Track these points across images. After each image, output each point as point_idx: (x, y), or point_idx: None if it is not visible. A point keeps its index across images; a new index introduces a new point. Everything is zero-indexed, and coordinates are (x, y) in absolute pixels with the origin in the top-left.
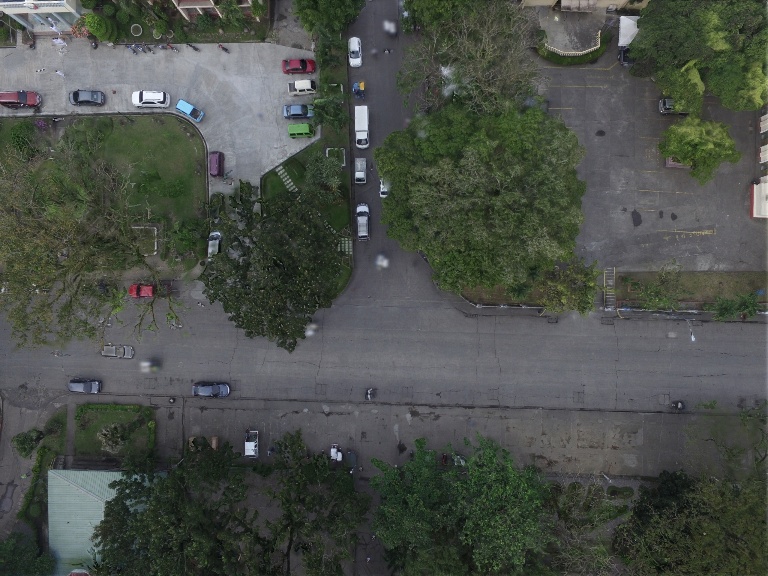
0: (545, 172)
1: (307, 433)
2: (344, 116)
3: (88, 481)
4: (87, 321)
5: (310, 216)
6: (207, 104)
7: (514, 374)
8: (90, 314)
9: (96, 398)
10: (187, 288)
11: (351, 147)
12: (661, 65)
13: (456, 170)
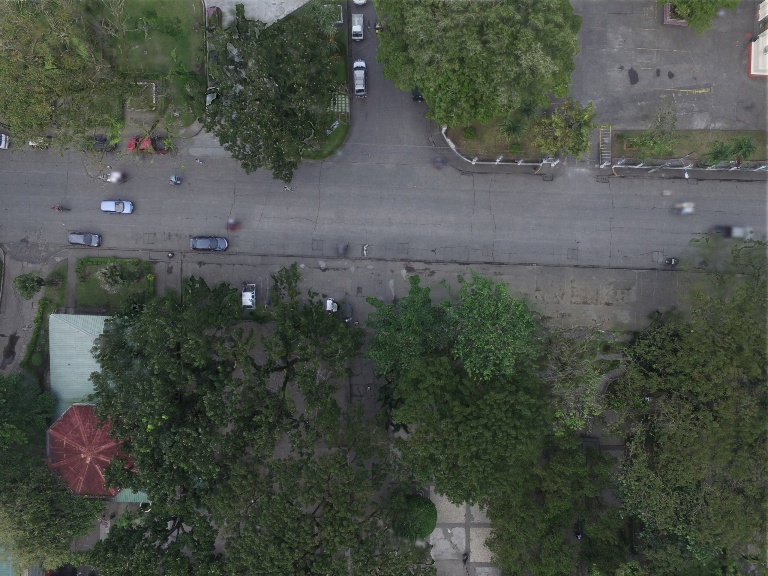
0: None
1: (304, 288)
2: None
3: (88, 324)
4: (85, 128)
5: (305, 36)
6: None
7: (509, 231)
8: (88, 122)
9: (96, 252)
10: (185, 145)
11: (348, 5)
12: None
13: None
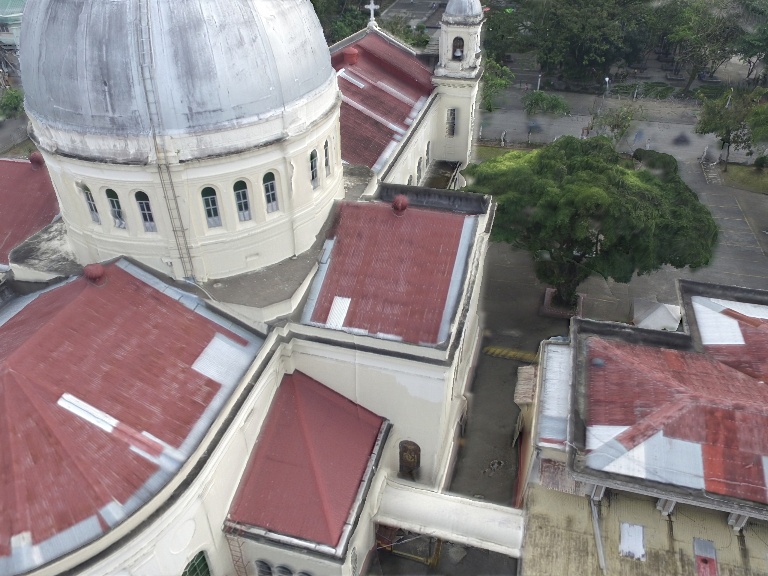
0: None
1: None
2: None
3: None
4: None
5: None
6: None
7: None
8: None
9: None
10: None
11: None
12: None
13: None
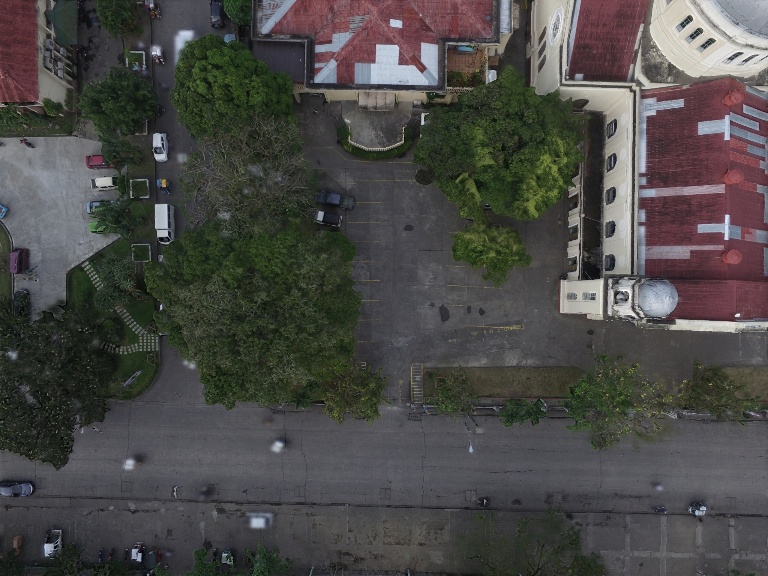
0: (293, 298)
1: (112, 531)
2: (127, 223)
3: None
4: None
5: (62, 340)
6: (12, 199)
7: (320, 471)
8: None
9: None
10: None
11: (158, 242)
12: (438, 175)
13: (203, 296)
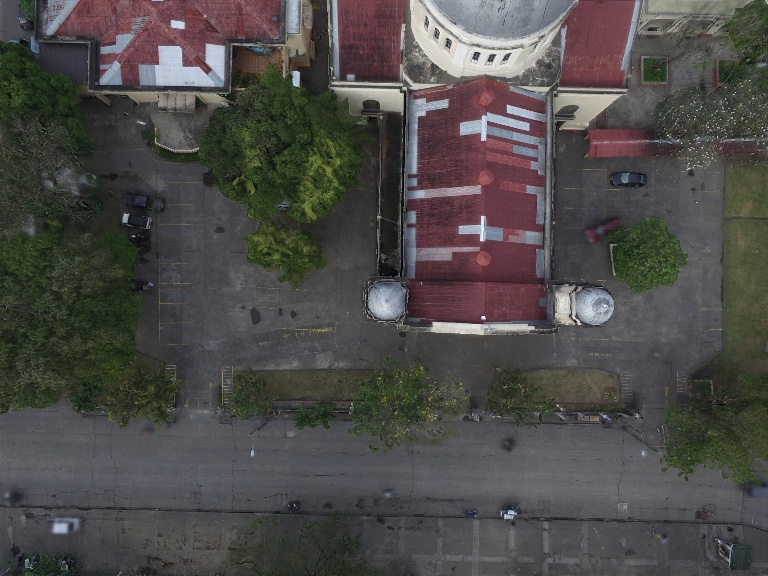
0: (44, 301)
1: None
2: None
3: None
4: None
5: None
6: None
7: (130, 475)
8: None
9: None
10: None
11: None
12: (217, 177)
13: None
